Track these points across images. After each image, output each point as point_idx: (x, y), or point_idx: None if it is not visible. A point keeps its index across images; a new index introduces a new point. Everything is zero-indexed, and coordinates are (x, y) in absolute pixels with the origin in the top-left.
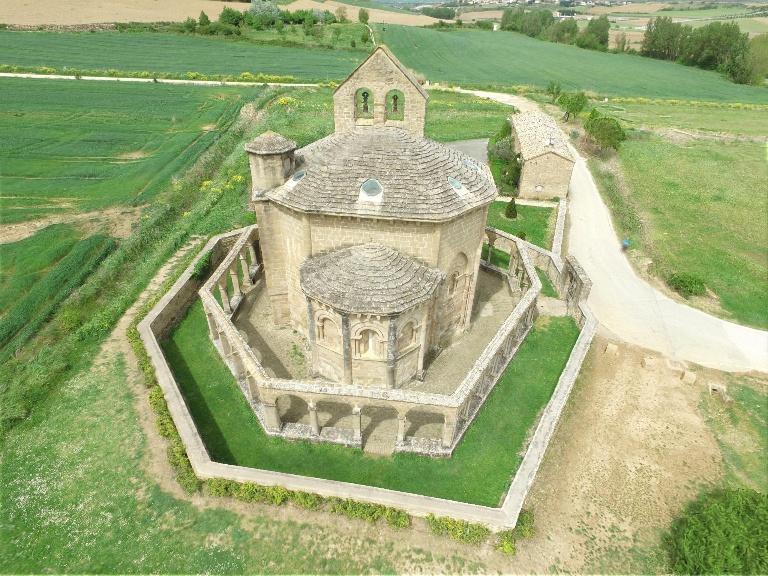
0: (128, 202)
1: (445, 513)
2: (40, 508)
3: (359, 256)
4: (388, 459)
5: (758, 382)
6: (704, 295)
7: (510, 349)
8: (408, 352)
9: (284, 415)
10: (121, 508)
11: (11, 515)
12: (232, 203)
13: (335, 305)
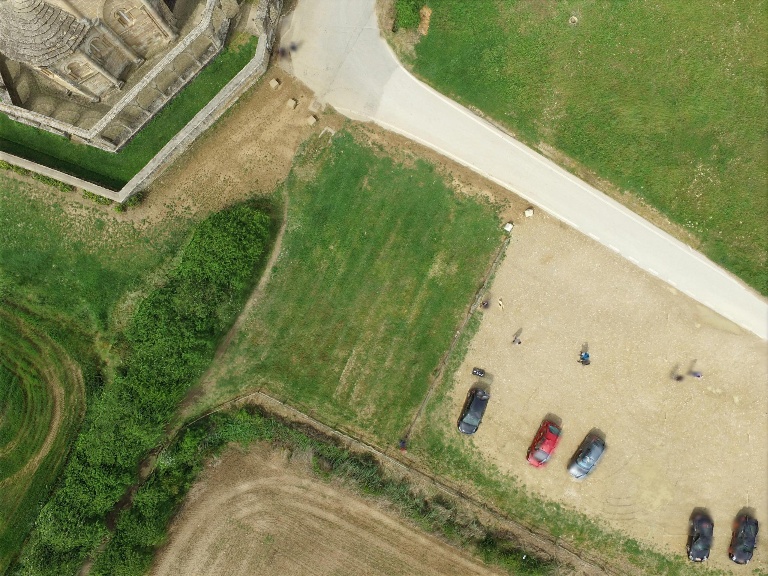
0: None
1: (88, 190)
2: None
3: (10, 4)
4: (84, 147)
5: (364, 132)
6: (412, 30)
7: (189, 73)
8: (88, 78)
9: (25, 103)
10: None
11: None
12: None
13: (1, 51)
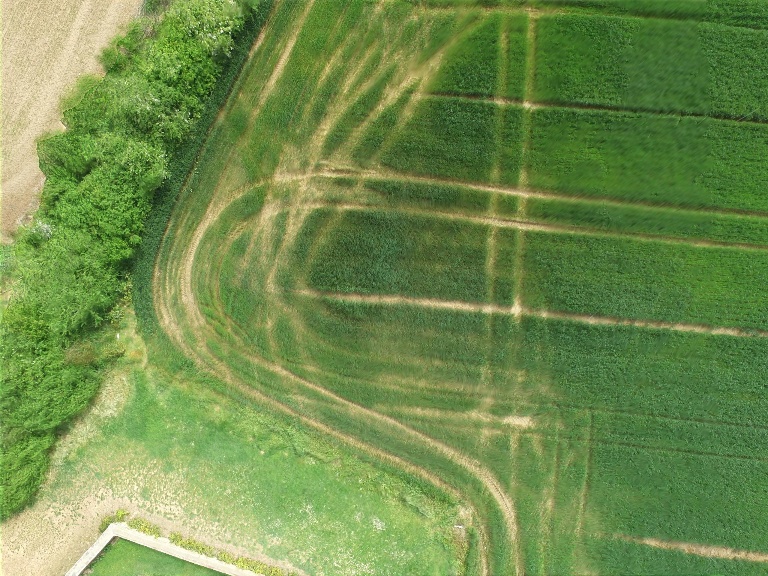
0: None
1: (147, 538)
2: (375, 575)
3: None
4: None
5: None
6: None
7: None
8: None
9: None
10: (331, 568)
11: (389, 573)
12: None
13: None
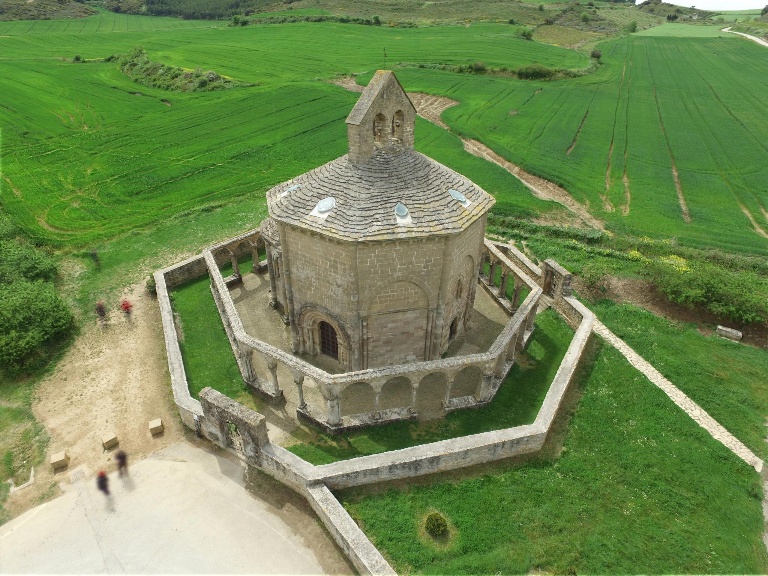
0: (610, 224)
1: None
2: None
3: None
4: None
5: None
6: None
7: None
8: None
9: None
10: None
11: None
12: (604, 263)
13: None
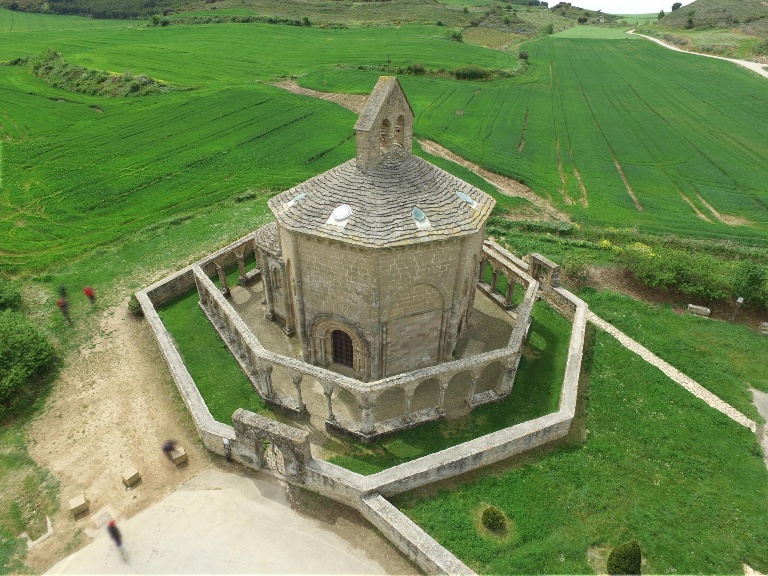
0: None
1: None
2: None
3: None
4: None
5: None
6: None
7: (246, 362)
8: None
9: None
10: None
11: None
12: (581, 254)
13: None
